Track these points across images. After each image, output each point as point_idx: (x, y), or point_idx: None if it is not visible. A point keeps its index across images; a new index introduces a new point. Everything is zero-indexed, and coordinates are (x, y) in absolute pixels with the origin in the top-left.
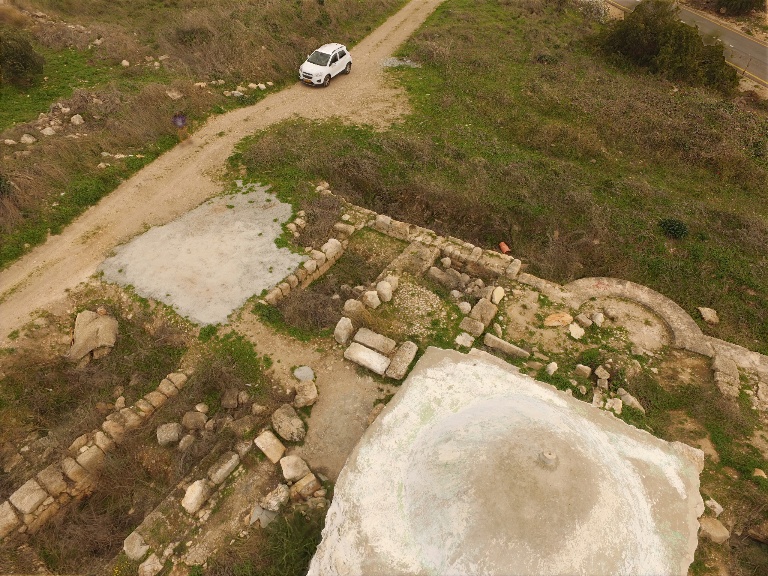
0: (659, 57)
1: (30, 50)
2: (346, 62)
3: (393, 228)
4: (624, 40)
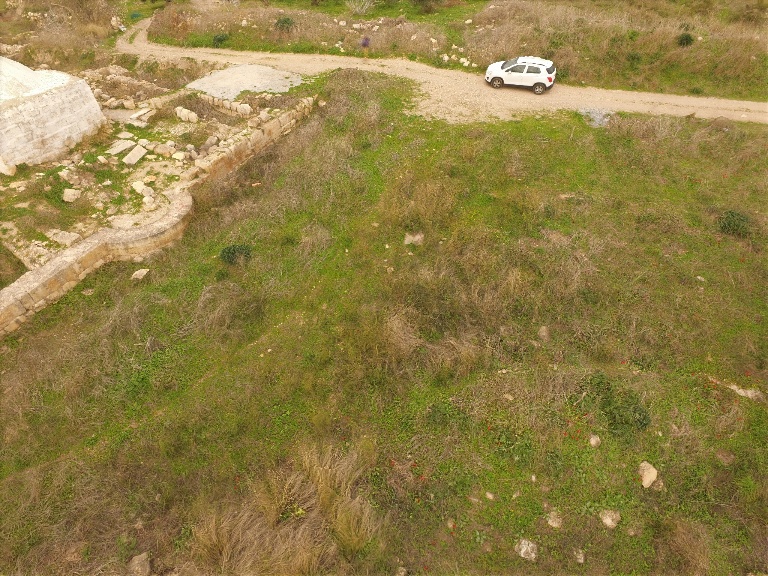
0: None
1: None
2: (536, 81)
3: None
4: None
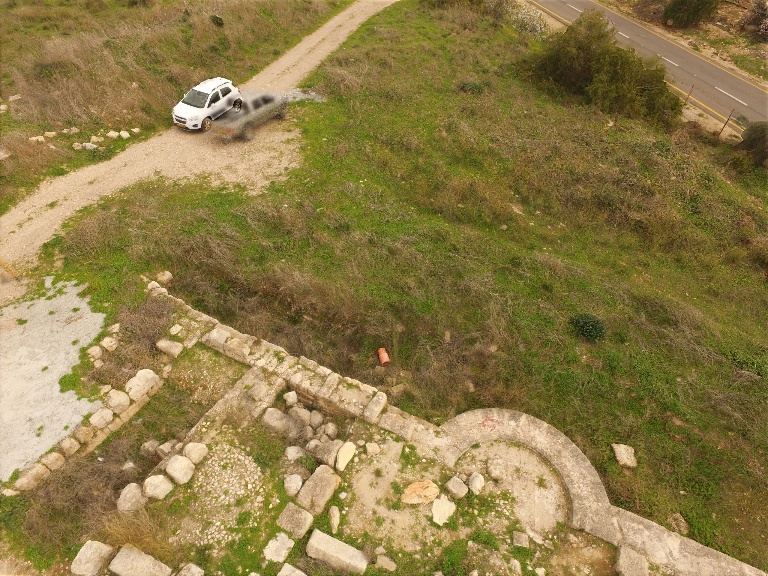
0: (592, 86)
1: None
2: (233, 100)
3: (228, 348)
4: (556, 65)
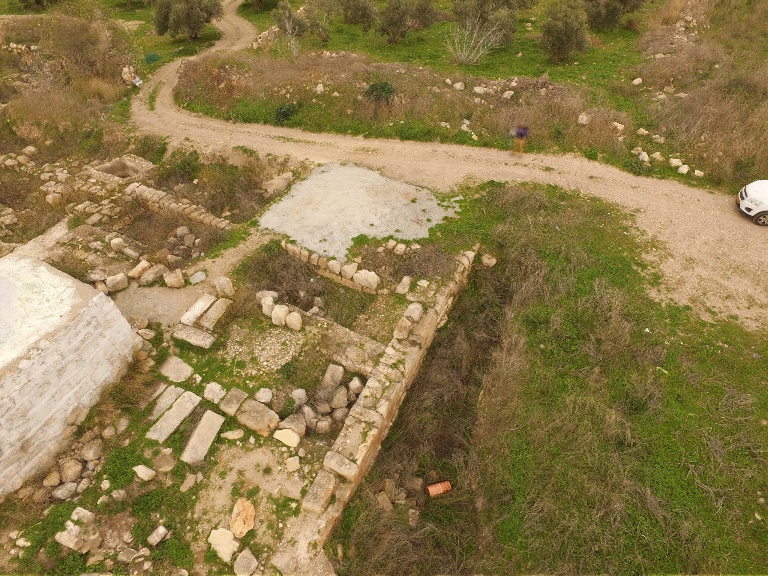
0: None
1: (569, 35)
2: None
3: None
4: None
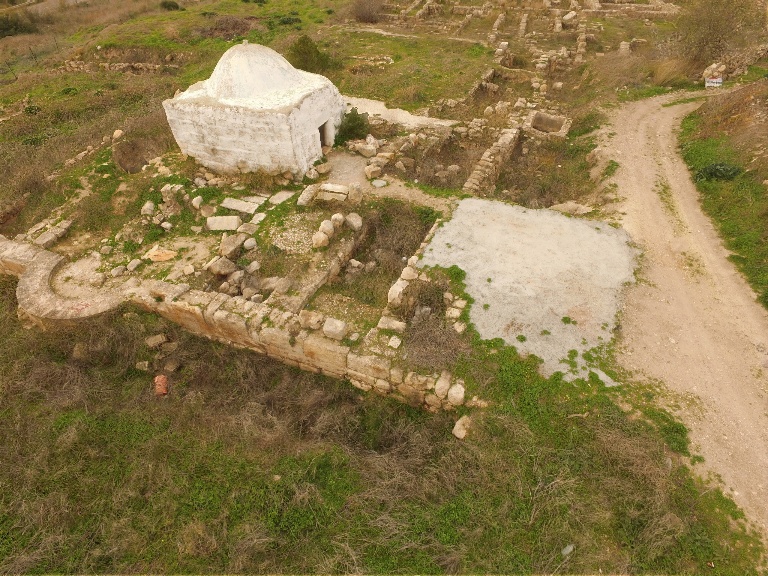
0: None
1: None
2: None
3: None
4: None
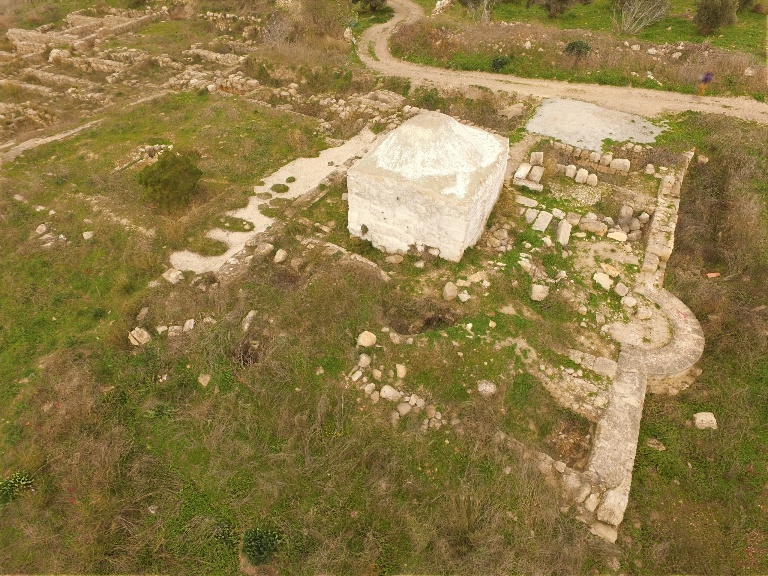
0: None
1: (724, 11)
2: None
3: None
4: None
